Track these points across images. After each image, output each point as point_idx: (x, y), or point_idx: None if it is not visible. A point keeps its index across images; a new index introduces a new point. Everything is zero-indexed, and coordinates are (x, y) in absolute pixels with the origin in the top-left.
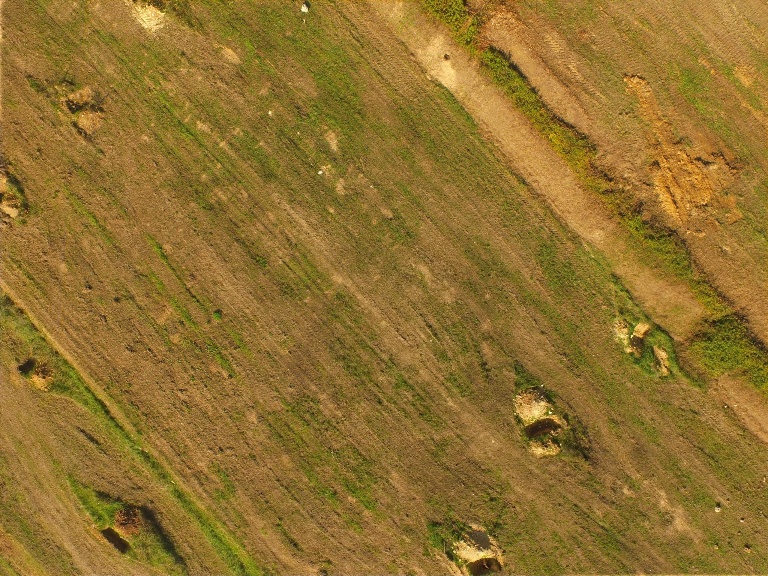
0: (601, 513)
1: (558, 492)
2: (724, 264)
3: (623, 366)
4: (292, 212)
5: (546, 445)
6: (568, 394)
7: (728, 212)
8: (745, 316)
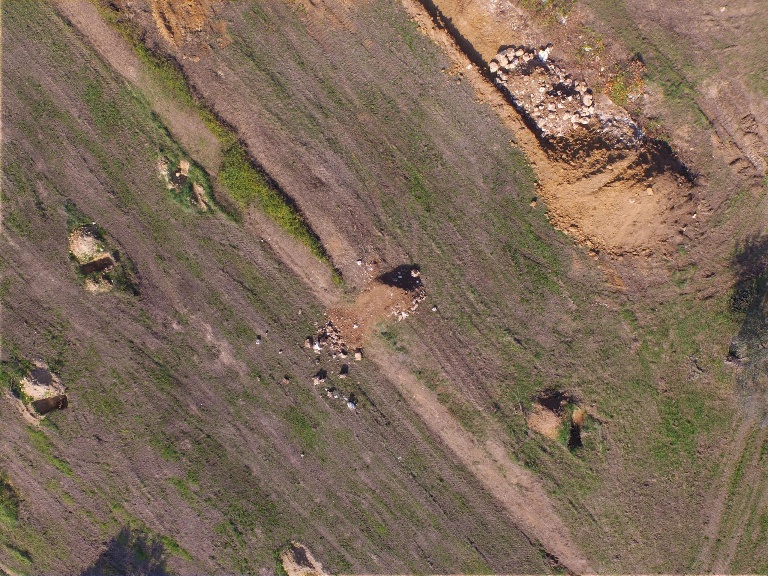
0: (154, 349)
1: (114, 329)
2: (218, 88)
3: (166, 202)
4: None
5: (97, 281)
6: (118, 231)
7: (219, 37)
8: (245, 140)
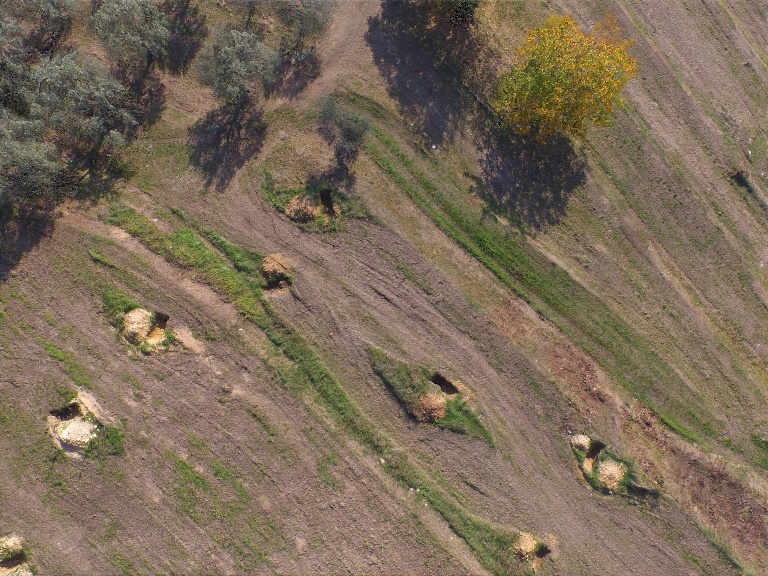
0: None
1: None
2: None
3: None
4: None
5: (4, 550)
6: None
7: None
8: None
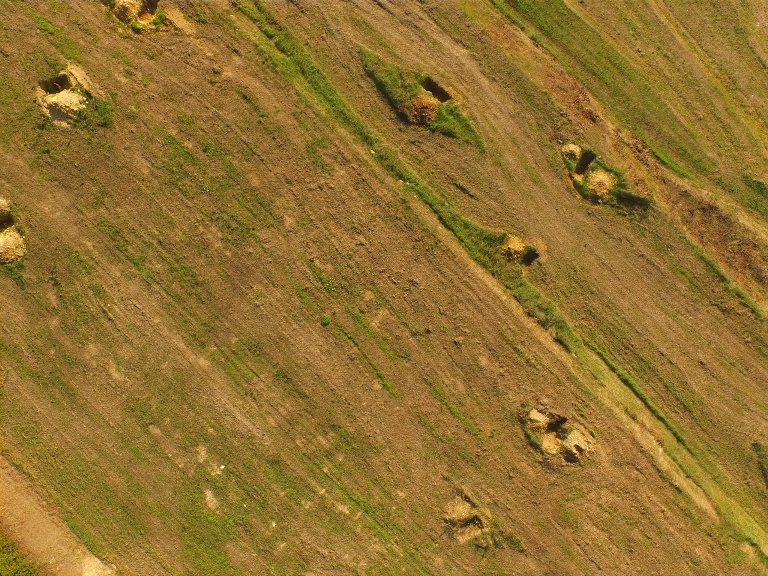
0: None
1: None
2: None
3: None
4: (251, 427)
5: None
6: None
7: None
8: None
